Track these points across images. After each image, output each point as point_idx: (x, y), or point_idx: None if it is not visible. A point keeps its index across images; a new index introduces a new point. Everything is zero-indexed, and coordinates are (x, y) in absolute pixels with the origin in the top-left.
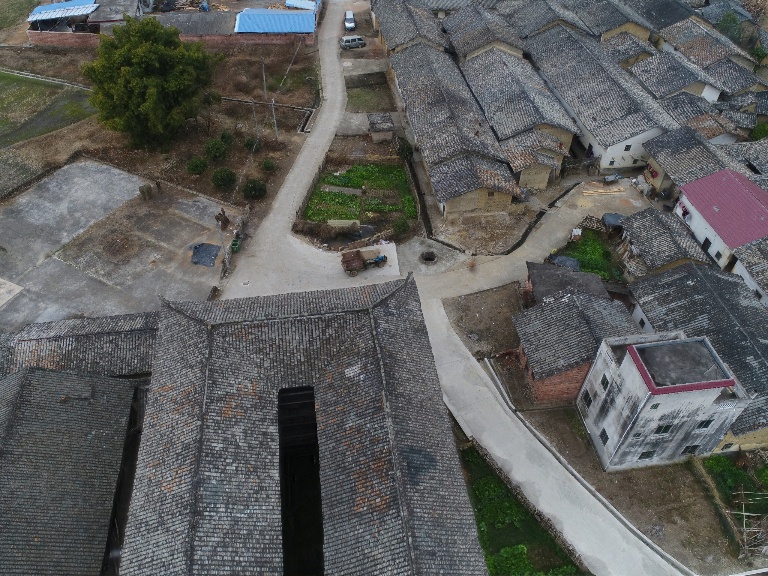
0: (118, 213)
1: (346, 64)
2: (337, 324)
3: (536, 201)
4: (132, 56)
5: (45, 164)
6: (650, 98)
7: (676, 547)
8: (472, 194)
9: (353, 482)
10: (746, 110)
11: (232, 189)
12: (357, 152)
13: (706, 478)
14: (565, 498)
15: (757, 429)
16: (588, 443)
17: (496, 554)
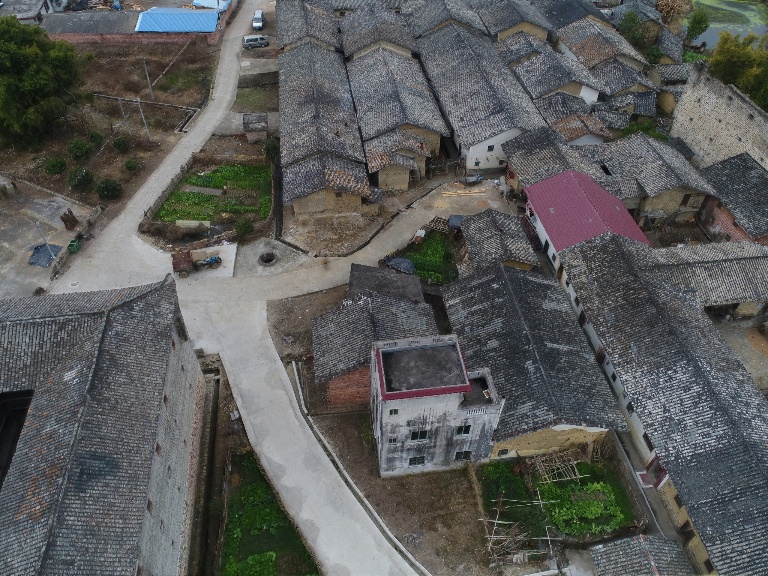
0: None
1: (244, 63)
2: (71, 327)
3: (395, 202)
4: None
5: None
6: (526, 98)
7: (429, 555)
8: (319, 195)
9: (26, 489)
10: (625, 110)
11: (91, 189)
12: (229, 152)
13: (474, 485)
14: (329, 504)
15: (517, 435)
16: (372, 448)
17: (243, 561)
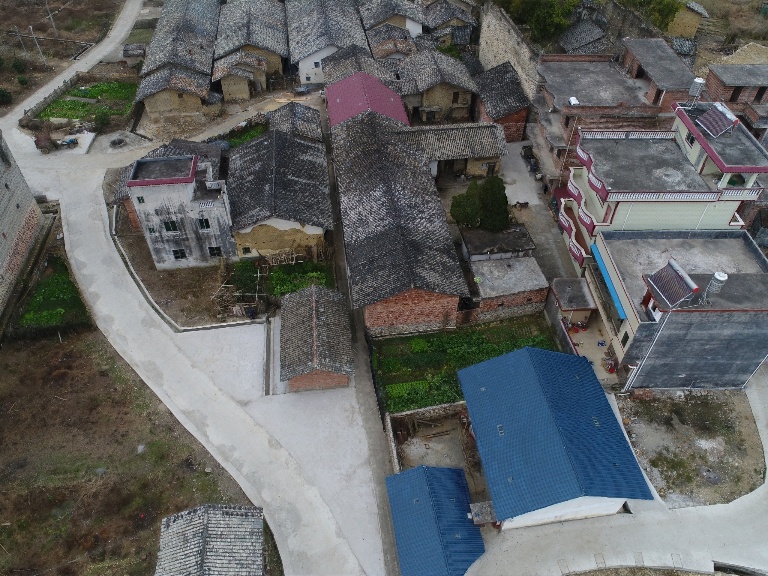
0: None
1: (144, 11)
2: None
3: (236, 107)
4: None
5: None
6: (359, 29)
7: (175, 311)
8: (164, 95)
9: None
10: (443, 40)
11: None
12: None
13: None
14: (113, 283)
15: (244, 228)
16: None
17: None
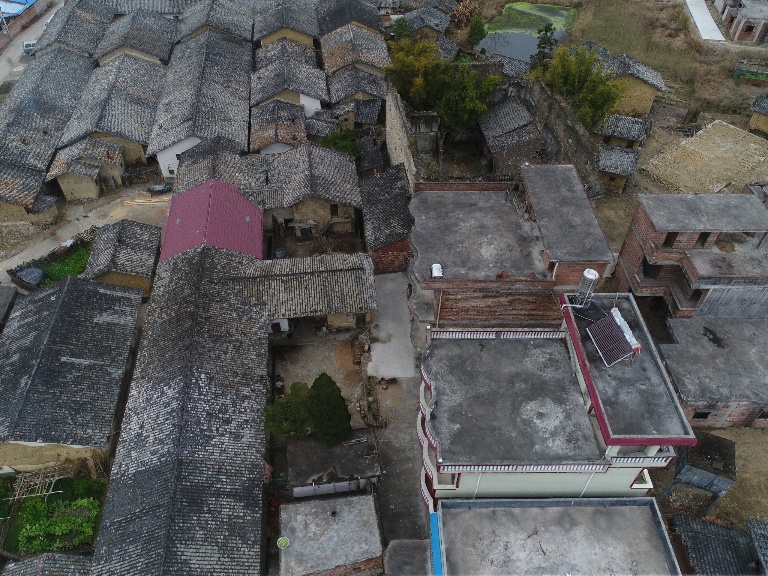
0: None
1: (17, 69)
2: None
3: (79, 210)
4: None
5: None
6: (243, 106)
7: None
8: None
9: None
10: (346, 118)
11: None
12: None
13: None
14: None
15: None
16: None
17: None
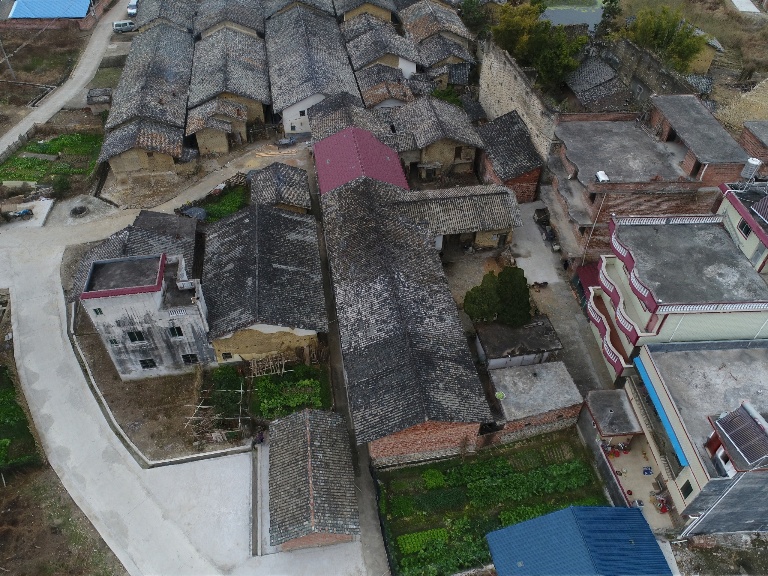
0: None
1: (111, 46)
2: None
3: (214, 163)
4: None
5: None
6: (347, 70)
7: (143, 438)
8: (131, 155)
9: None
10: (440, 80)
11: None
12: (73, 123)
13: None
14: (69, 402)
15: (223, 335)
16: None
17: None
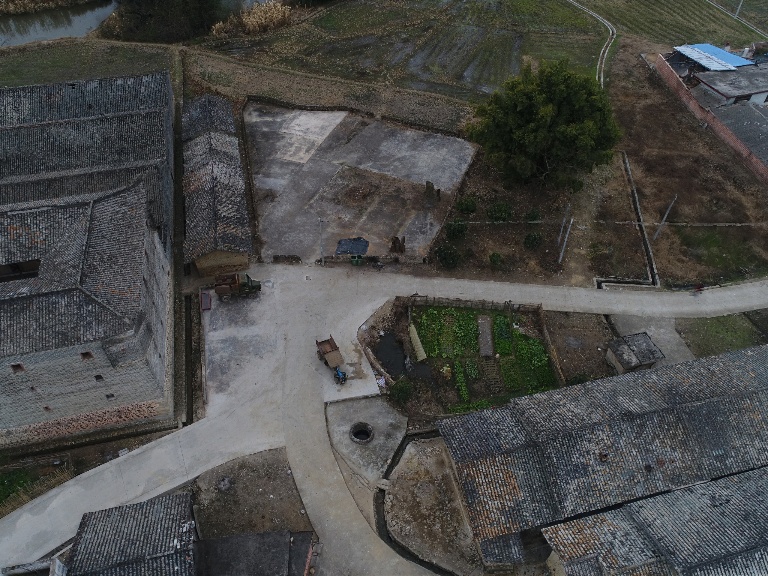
0: (402, 183)
1: None
2: None
3: None
4: (515, 88)
5: (461, 129)
6: None
7: None
8: None
9: None
10: None
11: (456, 244)
12: (574, 341)
13: None
14: None
15: None
16: None
17: None
